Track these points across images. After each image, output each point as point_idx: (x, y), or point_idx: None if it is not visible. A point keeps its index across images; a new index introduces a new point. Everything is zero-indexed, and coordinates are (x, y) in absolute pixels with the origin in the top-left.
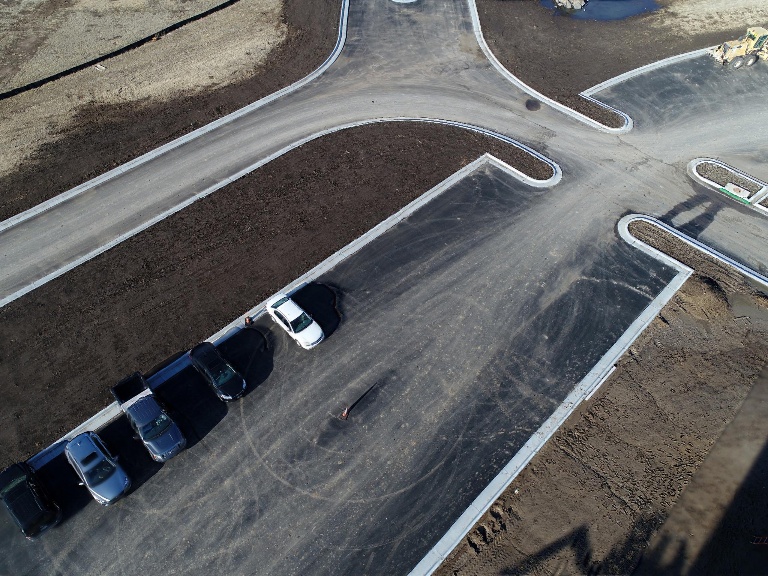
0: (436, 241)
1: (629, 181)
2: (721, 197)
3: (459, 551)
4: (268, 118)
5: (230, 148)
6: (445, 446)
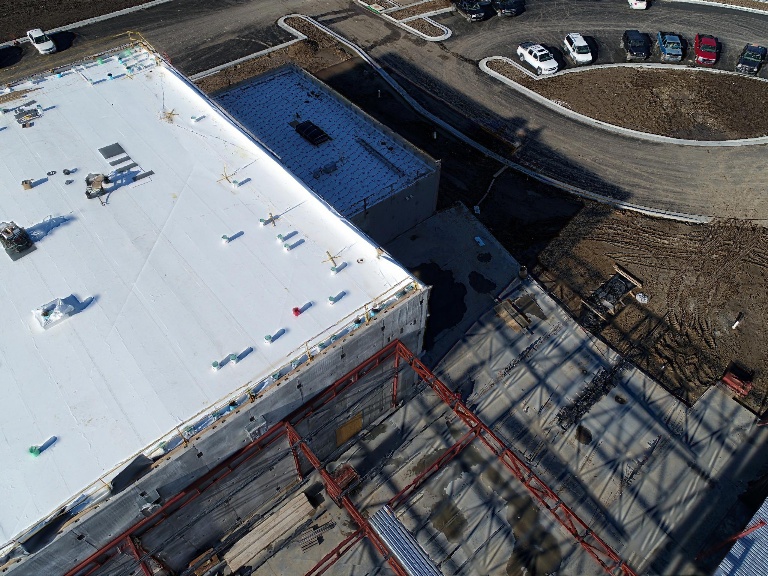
0: (156, 19)
1: None
2: (364, 10)
3: None
4: None
5: None
6: None
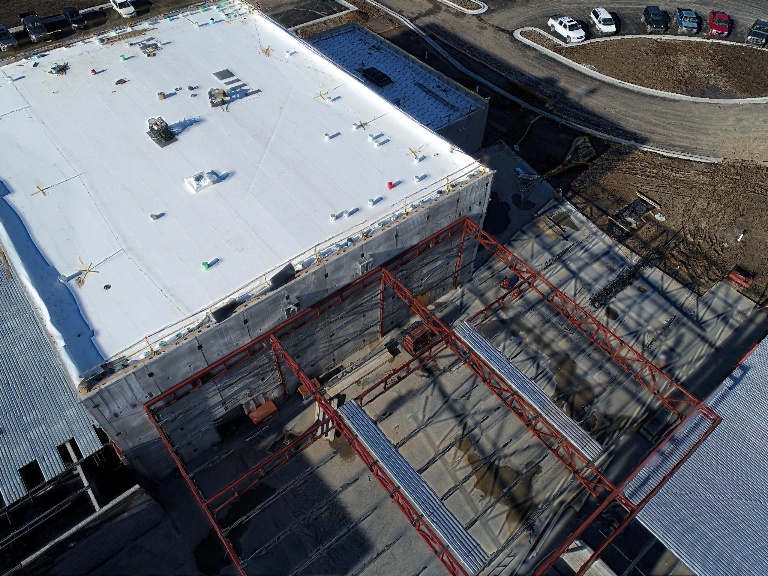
0: None
1: None
2: None
3: None
4: None
5: None
6: None
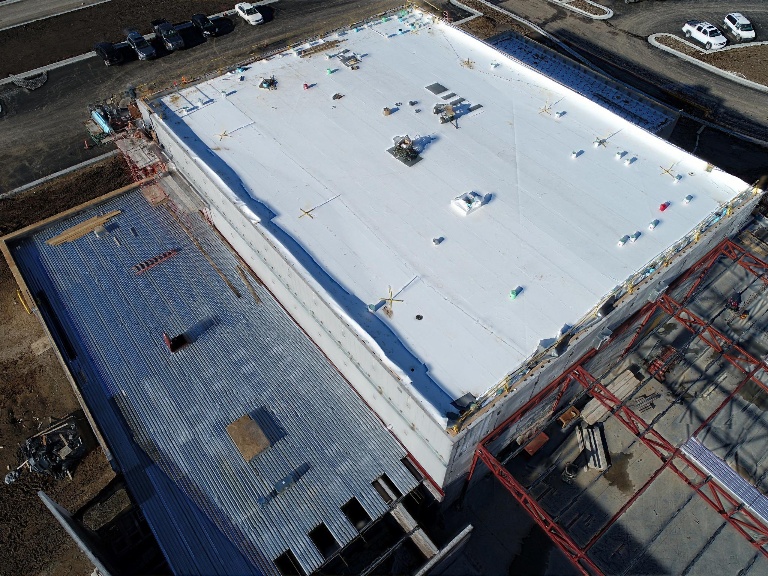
0: None
1: None
2: None
3: None
4: None
5: None
6: None
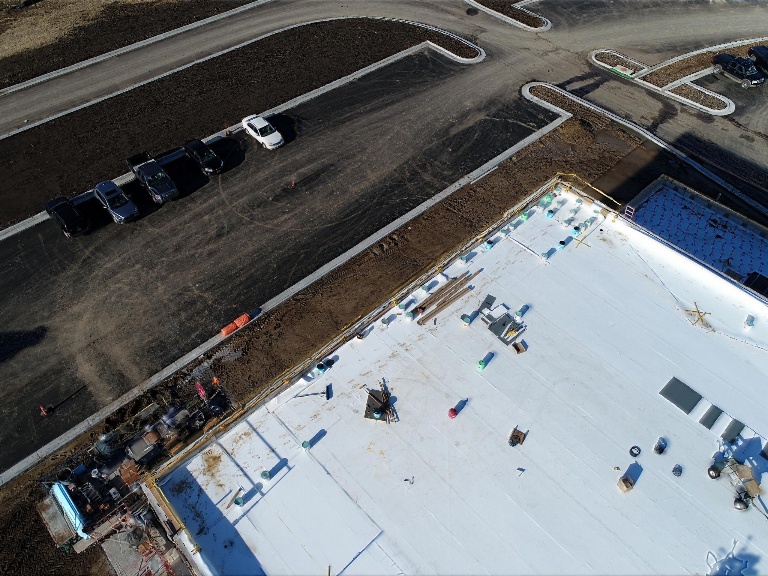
0: (377, 93)
1: (538, 62)
2: (610, 74)
3: (363, 255)
4: (256, 15)
5: (224, 33)
6: (363, 204)
